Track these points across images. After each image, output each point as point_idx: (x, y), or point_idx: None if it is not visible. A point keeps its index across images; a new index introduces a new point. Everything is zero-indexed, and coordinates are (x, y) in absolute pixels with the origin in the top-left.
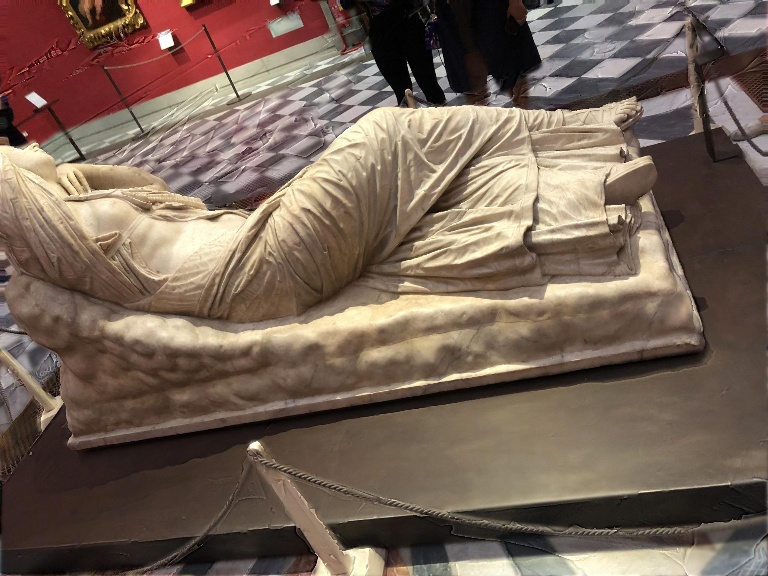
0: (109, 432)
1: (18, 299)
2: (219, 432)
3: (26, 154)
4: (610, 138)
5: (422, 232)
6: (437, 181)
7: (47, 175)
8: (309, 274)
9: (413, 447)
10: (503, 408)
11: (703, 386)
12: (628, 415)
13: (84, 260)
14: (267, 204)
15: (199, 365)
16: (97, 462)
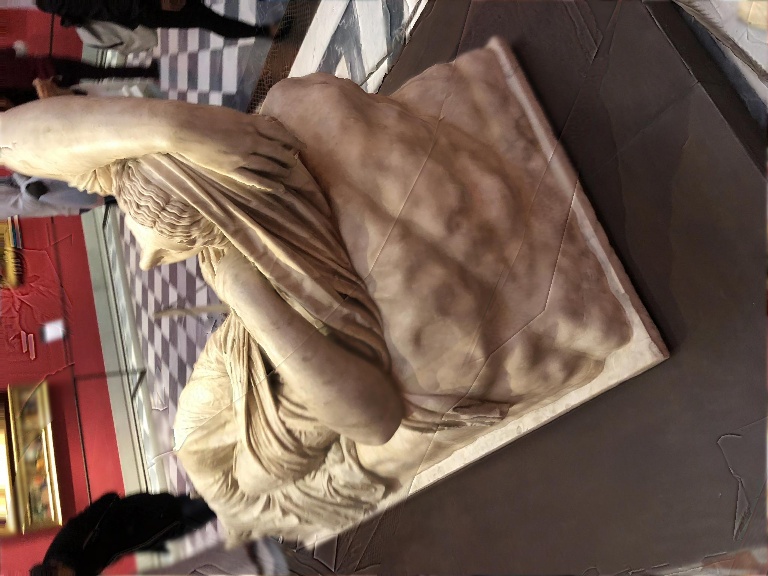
0: None
1: None
2: None
3: None
4: None
5: None
6: None
7: None
8: None
9: None
10: None
11: None
12: None
13: None
14: None
15: None
16: None
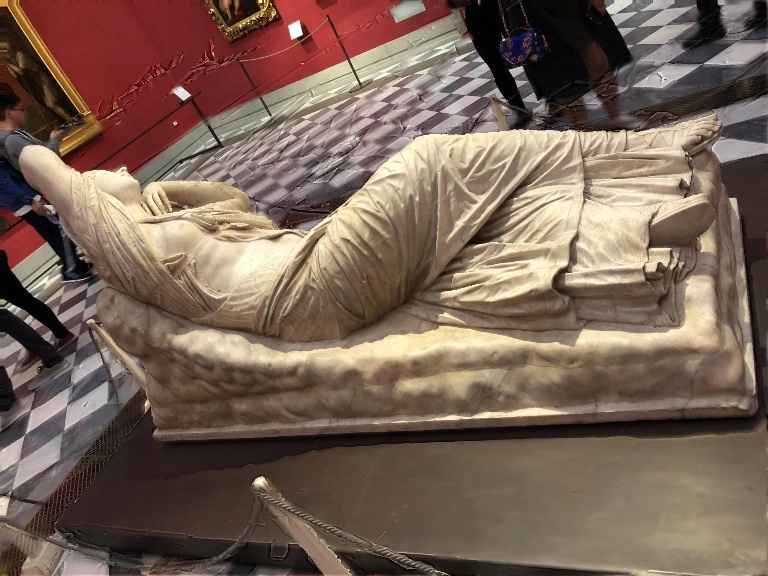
0: (185, 429)
1: (104, 310)
2: (274, 441)
3: (114, 179)
4: (673, 166)
5: (462, 263)
6: (477, 212)
7: (131, 198)
8: (350, 301)
9: (438, 482)
10: (532, 453)
11: (746, 457)
12: (657, 480)
13: (154, 279)
14: (314, 231)
15: (252, 380)
16: (176, 454)
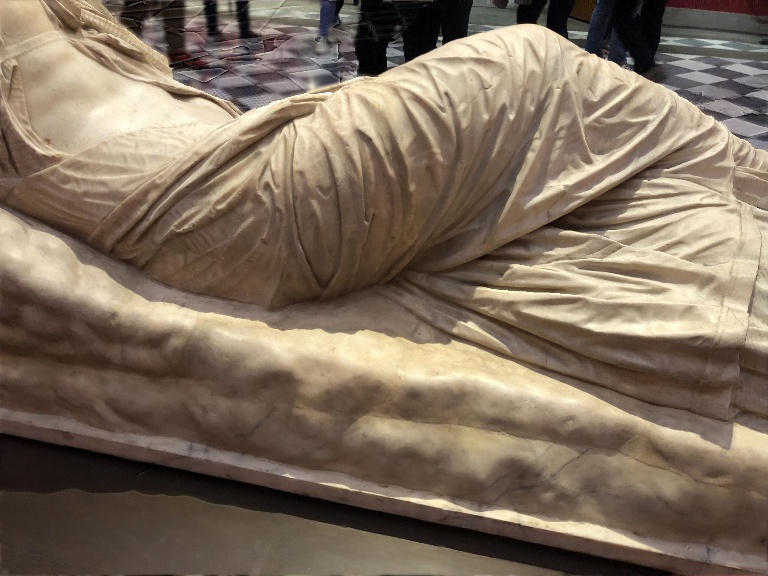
0: None
1: None
2: (52, 450)
3: None
4: None
5: (530, 251)
6: (590, 179)
7: None
8: (321, 248)
9: None
10: None
11: None
12: None
13: None
14: (291, 102)
15: (60, 331)
16: None
